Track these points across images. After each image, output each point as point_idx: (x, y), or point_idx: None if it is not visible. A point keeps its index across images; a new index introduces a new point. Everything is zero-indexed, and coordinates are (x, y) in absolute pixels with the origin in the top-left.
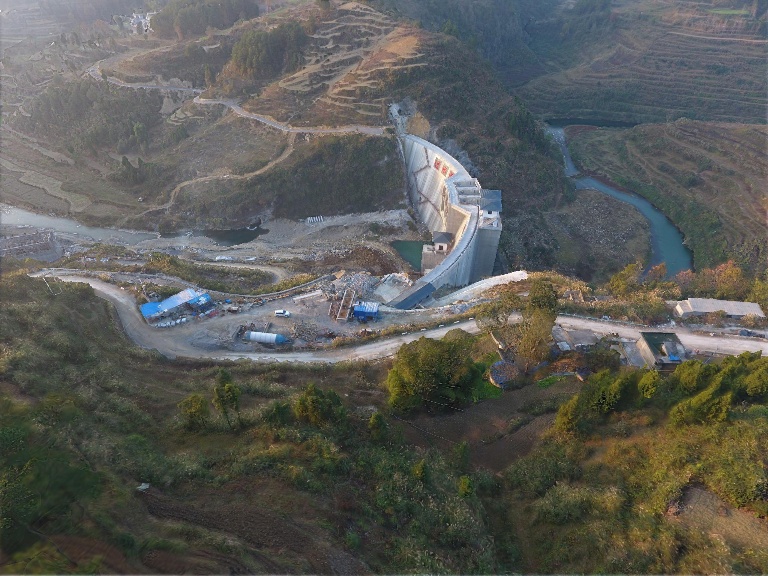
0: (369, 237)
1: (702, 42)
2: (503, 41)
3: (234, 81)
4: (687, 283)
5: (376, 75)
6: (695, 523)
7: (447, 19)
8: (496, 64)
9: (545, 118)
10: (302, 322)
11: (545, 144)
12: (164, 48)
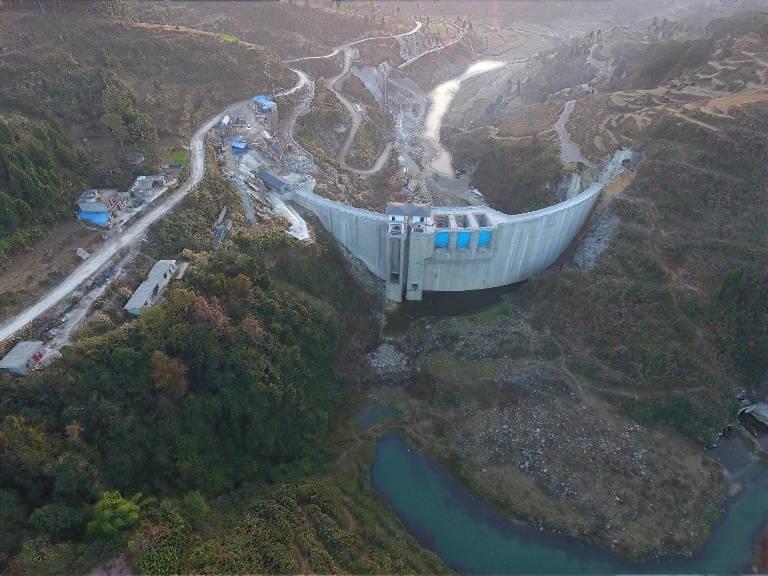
0: None
1: None
2: None
3: (613, 78)
4: None
5: (657, 114)
6: None
7: None
8: None
9: None
10: None
11: None
12: None
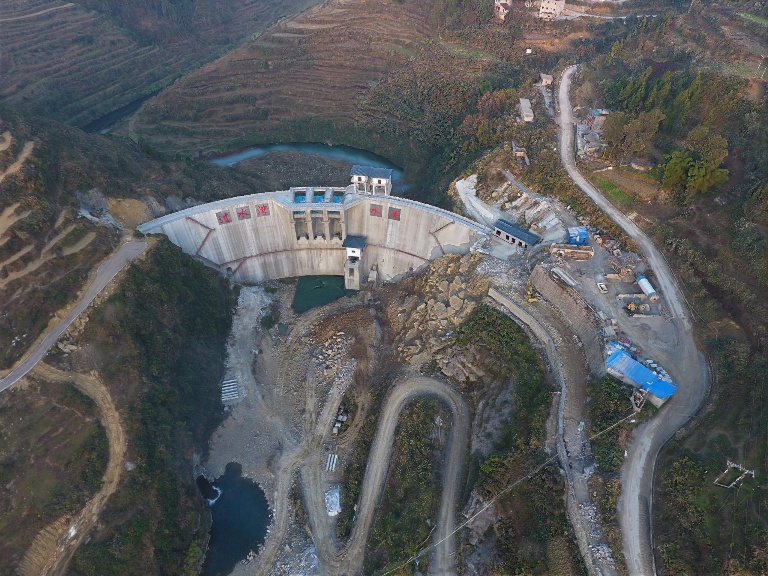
0: (279, 333)
1: (32, 21)
2: None
3: None
4: None
5: (5, 197)
6: (757, 98)
7: None
8: None
9: None
10: None
11: None
12: None
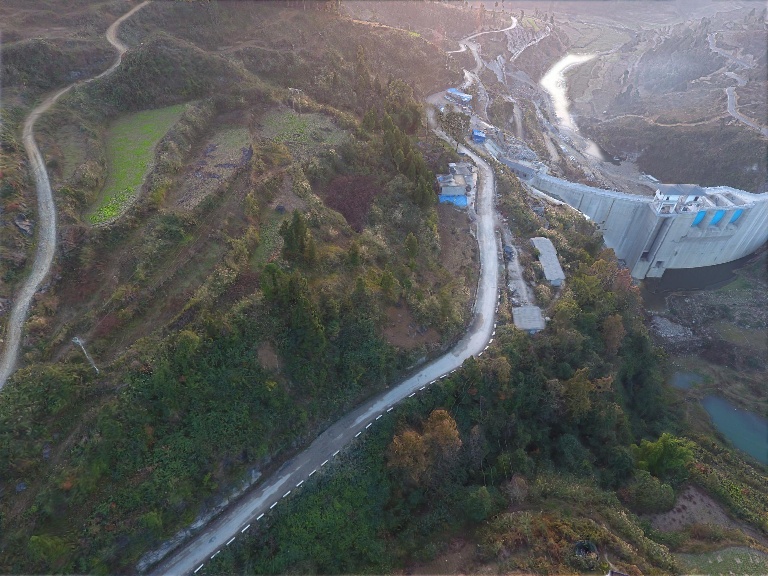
0: None
1: None
2: None
3: (767, 65)
4: None
5: None
6: None
7: None
8: None
9: None
10: None
11: None
12: None
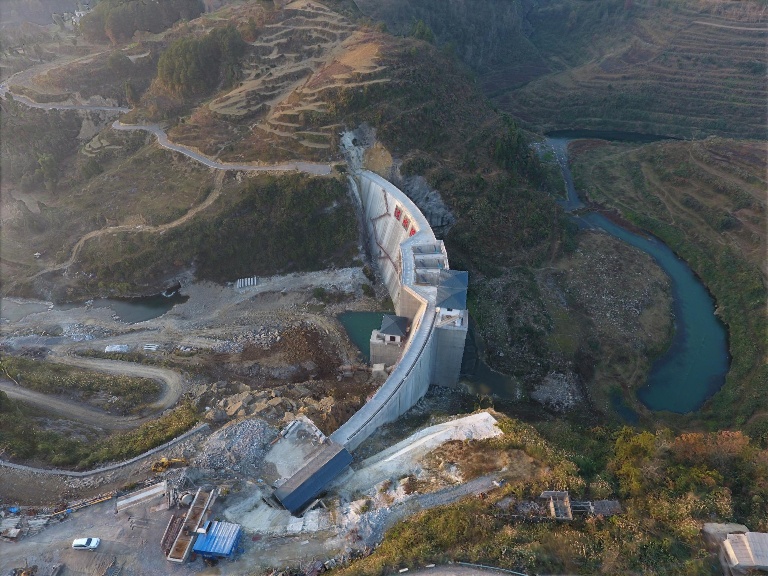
0: (312, 306)
1: (734, 34)
2: (499, 34)
3: (158, 101)
4: (735, 453)
5: (325, 95)
6: None
7: (432, 11)
8: (491, 62)
9: (545, 130)
10: (107, 570)
11: (541, 173)
12: (86, 58)
